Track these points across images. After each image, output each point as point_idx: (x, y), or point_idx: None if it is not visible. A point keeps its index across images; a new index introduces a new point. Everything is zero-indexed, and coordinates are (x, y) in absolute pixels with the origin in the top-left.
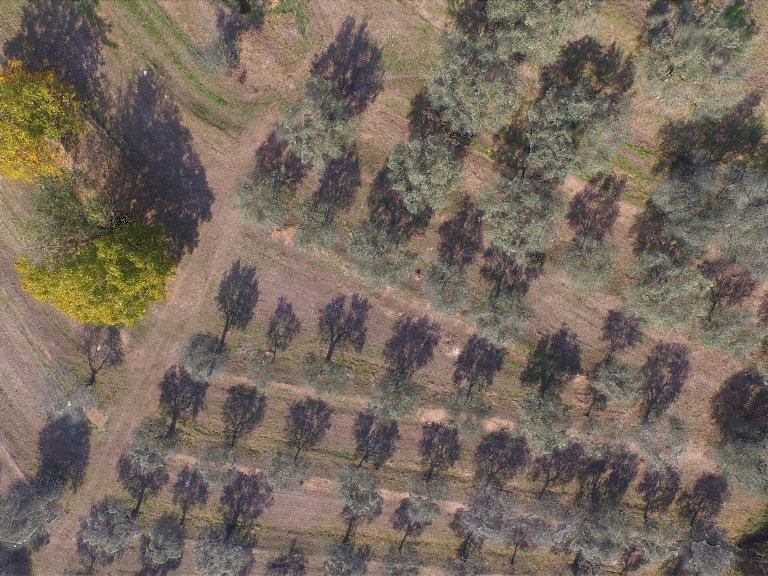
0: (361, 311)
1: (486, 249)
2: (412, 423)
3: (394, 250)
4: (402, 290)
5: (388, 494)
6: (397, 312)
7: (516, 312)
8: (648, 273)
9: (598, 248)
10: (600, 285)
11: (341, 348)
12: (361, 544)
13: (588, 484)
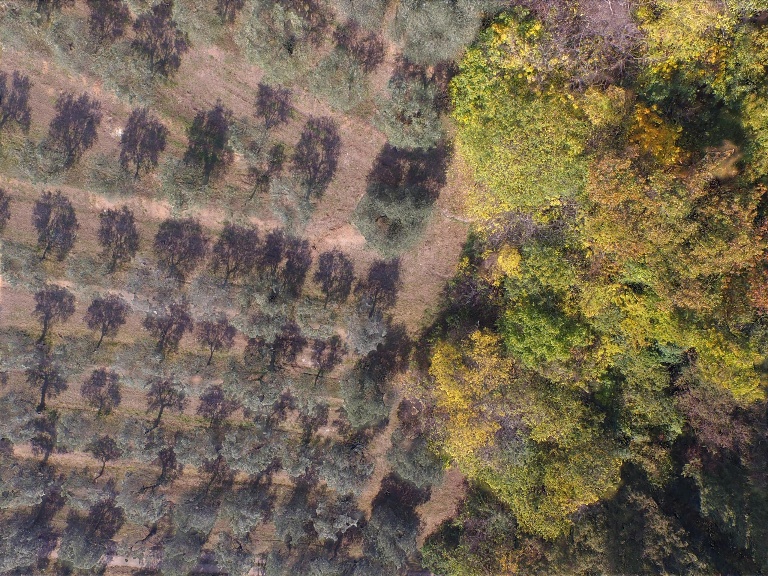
0: (23, 90)
1: (135, 21)
2: (89, 211)
3: (46, 22)
4: (56, 64)
5: (76, 289)
6: (58, 90)
7: (171, 87)
8: (285, 40)
9: (240, 18)
10: (243, 55)
11: (8, 130)
12: (58, 344)
13: (267, 275)
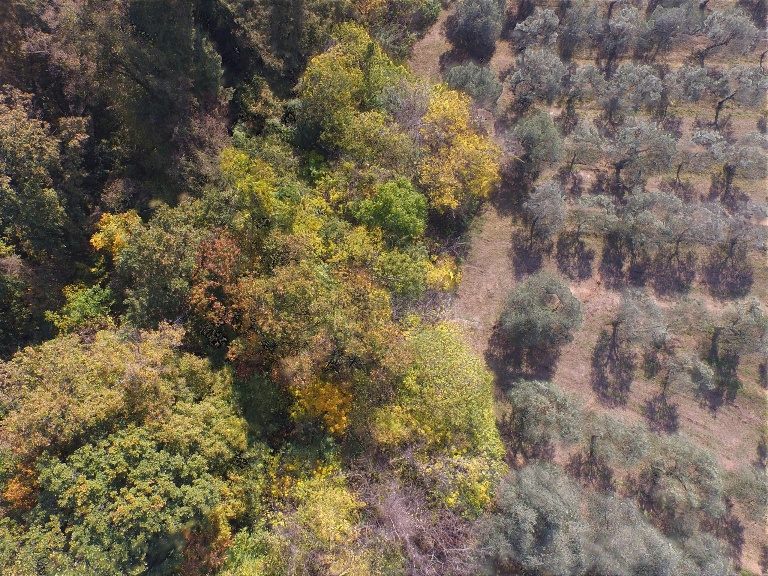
0: None
1: None
2: None
3: None
4: None
5: None
6: None
7: (763, 426)
8: None
9: None
10: None
11: None
12: None
13: (639, 254)
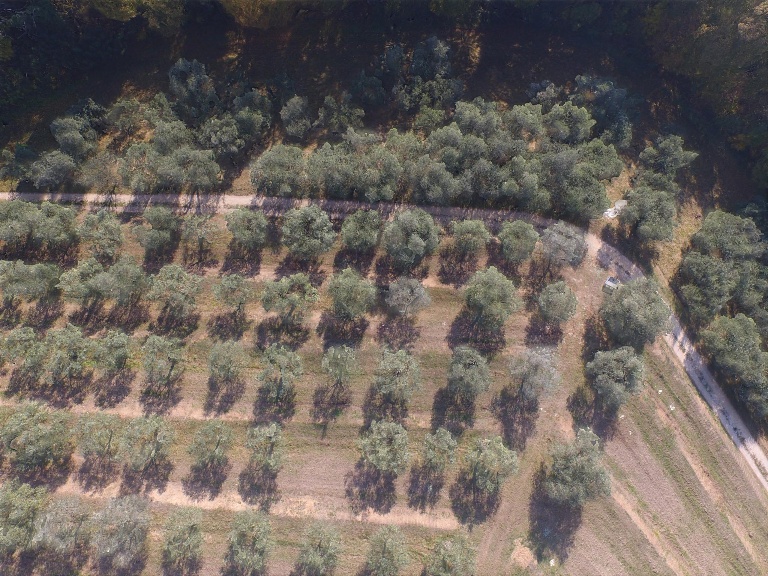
0: None
1: None
2: None
3: None
4: None
5: (232, 501)
6: None
7: None
8: None
9: None
10: None
11: None
12: None
13: None
